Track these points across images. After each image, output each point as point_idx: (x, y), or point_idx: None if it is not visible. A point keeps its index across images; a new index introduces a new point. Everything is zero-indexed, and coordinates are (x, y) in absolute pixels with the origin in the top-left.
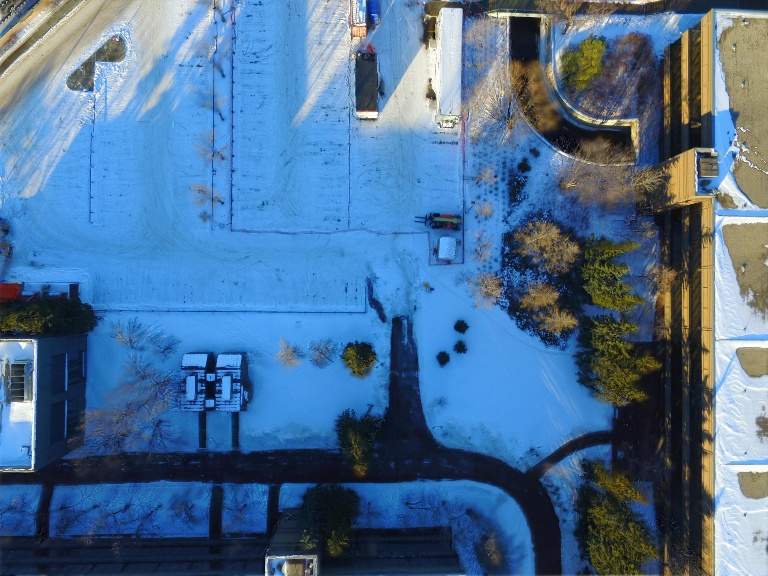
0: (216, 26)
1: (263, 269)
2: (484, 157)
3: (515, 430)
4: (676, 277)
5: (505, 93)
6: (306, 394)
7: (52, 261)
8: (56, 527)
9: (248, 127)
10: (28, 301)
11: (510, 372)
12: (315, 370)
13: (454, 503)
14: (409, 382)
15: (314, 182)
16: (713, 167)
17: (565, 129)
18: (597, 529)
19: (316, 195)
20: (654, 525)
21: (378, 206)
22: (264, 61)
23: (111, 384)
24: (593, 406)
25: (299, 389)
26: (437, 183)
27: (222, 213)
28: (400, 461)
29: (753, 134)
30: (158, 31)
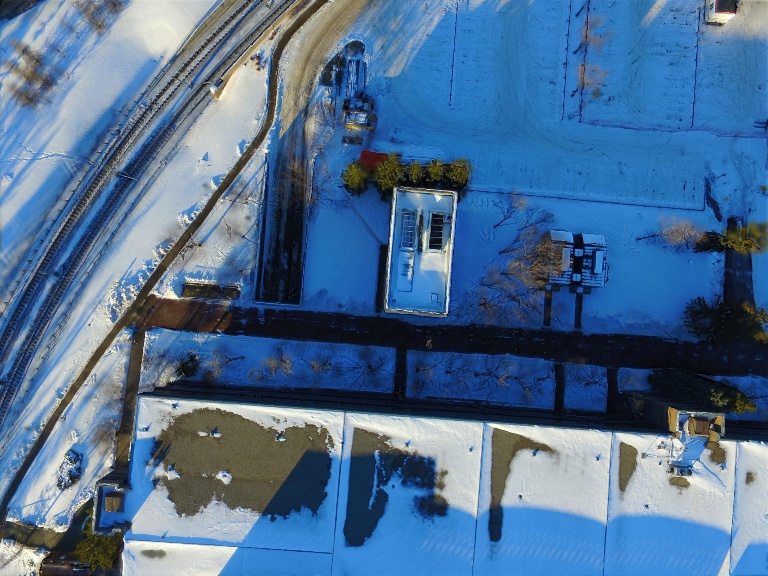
0: None
1: (606, 162)
2: None
3: None
4: None
5: None
6: (647, 283)
7: (411, 139)
8: (413, 387)
9: (599, 24)
10: None
11: None
12: (658, 260)
13: None
14: (743, 281)
15: (659, 82)
16: None
17: None
18: None
19: (660, 94)
20: None
21: (719, 109)
22: None
23: (466, 257)
24: None
25: (641, 278)
26: None
27: (572, 104)
28: (733, 356)
29: None
30: None
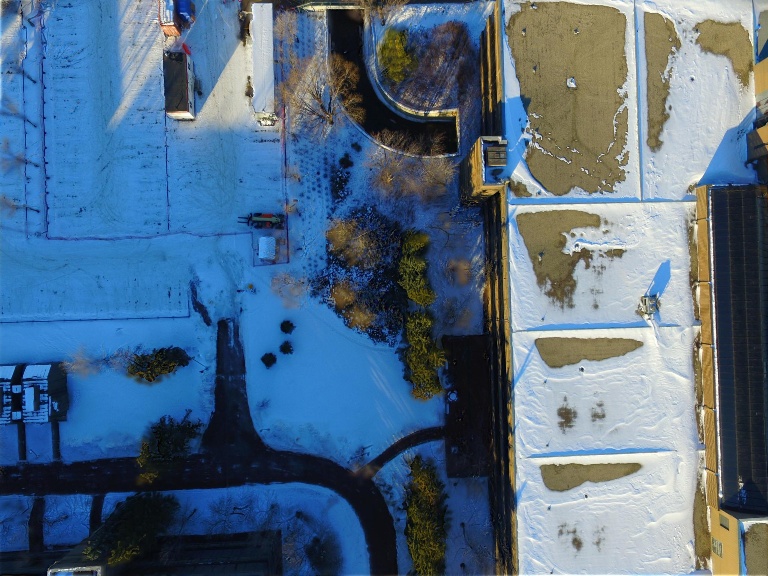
0: (25, 31)
1: (83, 277)
2: (305, 154)
3: (344, 430)
4: (492, 268)
5: (325, 88)
6: (128, 402)
7: None
8: None
9: (62, 133)
10: None
11: (339, 371)
12: (136, 377)
13: (283, 506)
14: (236, 385)
15: (133, 186)
16: (501, 155)
17: (393, 122)
18: (414, 528)
19: (135, 199)
20: (488, 520)
21: (200, 208)
22: (76, 65)
23: None
24: (424, 402)
25: (120, 397)
26: (260, 182)
27: (37, 221)
28: (227, 466)
29: (546, 120)
30: None
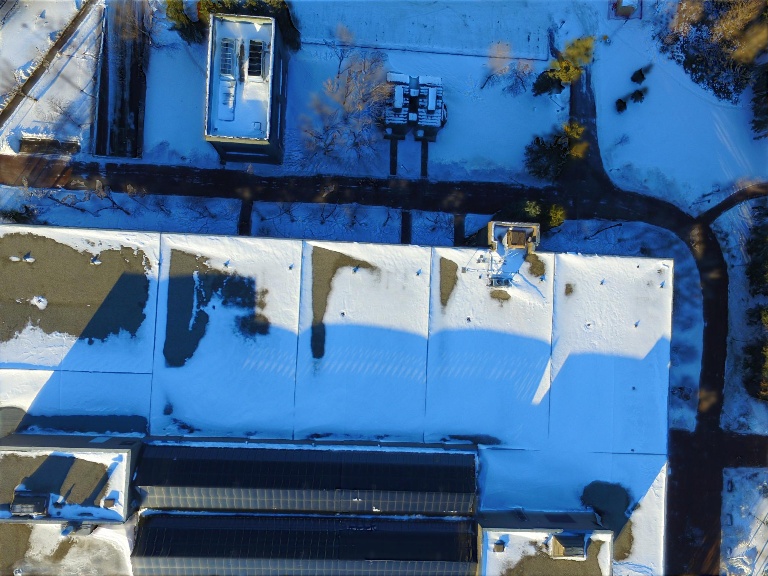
0: None
1: (451, 14)
2: None
3: (689, 176)
4: None
5: None
6: (492, 130)
7: None
8: None
9: None
10: None
11: (684, 123)
12: (501, 107)
13: (629, 241)
14: (587, 127)
15: None
16: None
17: None
18: None
19: None
20: None
21: None
22: None
23: (310, 108)
24: (763, 159)
25: (485, 125)
26: None
27: None
28: (578, 200)
29: None
30: None
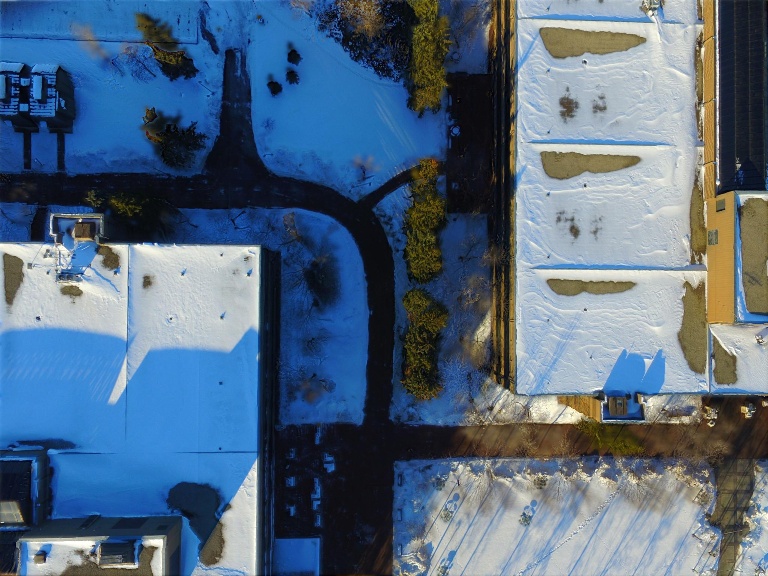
0: None
1: None
2: None
3: (347, 159)
4: None
5: None
6: (134, 118)
7: None
8: None
9: None
10: None
11: (343, 103)
12: (142, 94)
13: (284, 229)
14: (241, 112)
15: None
16: None
17: None
18: None
19: None
20: (486, 253)
21: None
22: None
23: None
24: (427, 137)
25: (127, 113)
26: None
27: None
28: (230, 188)
29: None
30: None
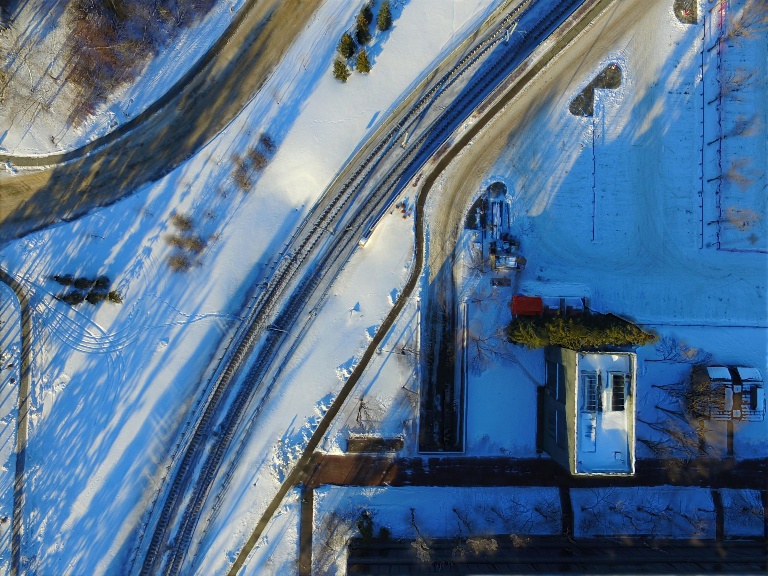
0: (702, 56)
1: (744, 286)
2: None
3: None
4: None
5: None
6: None
7: (556, 276)
8: (580, 527)
9: (730, 152)
10: (560, 314)
11: None
12: None
13: None
14: None
15: None
16: None
17: None
18: None
19: None
20: None
21: None
22: (745, 89)
23: None
24: None
25: None
26: None
27: (710, 233)
28: None
29: None
30: (650, 60)
